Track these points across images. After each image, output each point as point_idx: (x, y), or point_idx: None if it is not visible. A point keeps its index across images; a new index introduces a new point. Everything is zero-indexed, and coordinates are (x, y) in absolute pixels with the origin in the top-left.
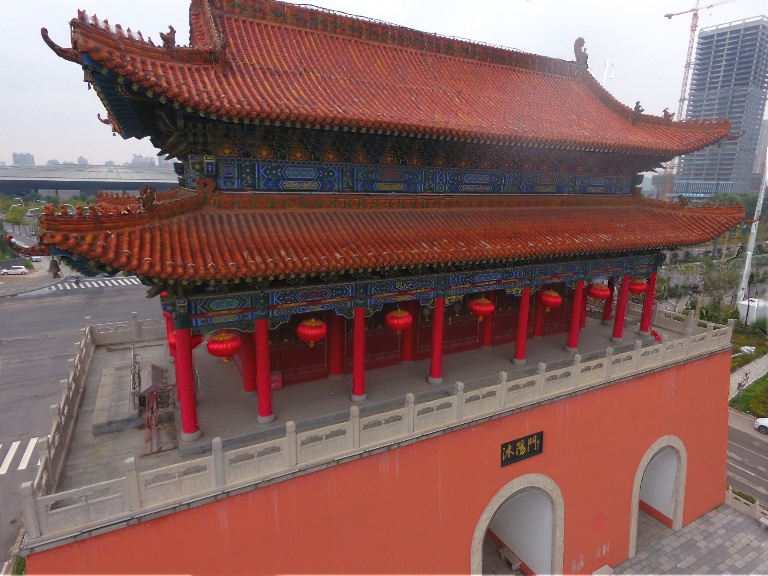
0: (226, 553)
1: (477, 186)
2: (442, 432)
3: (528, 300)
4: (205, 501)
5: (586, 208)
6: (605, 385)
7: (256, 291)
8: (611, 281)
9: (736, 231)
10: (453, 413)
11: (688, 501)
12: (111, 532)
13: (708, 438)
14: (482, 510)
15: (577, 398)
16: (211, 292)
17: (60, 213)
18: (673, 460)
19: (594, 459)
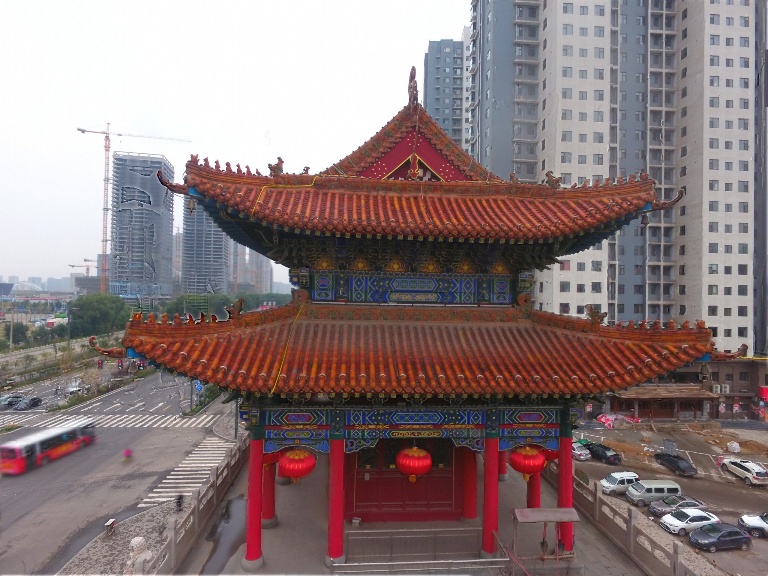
0: None
1: None
2: None
3: None
4: None
5: None
6: None
7: None
8: None
9: None
10: None
11: None
12: None
13: None
14: None
15: None
16: None
17: (692, 327)
18: None
19: None
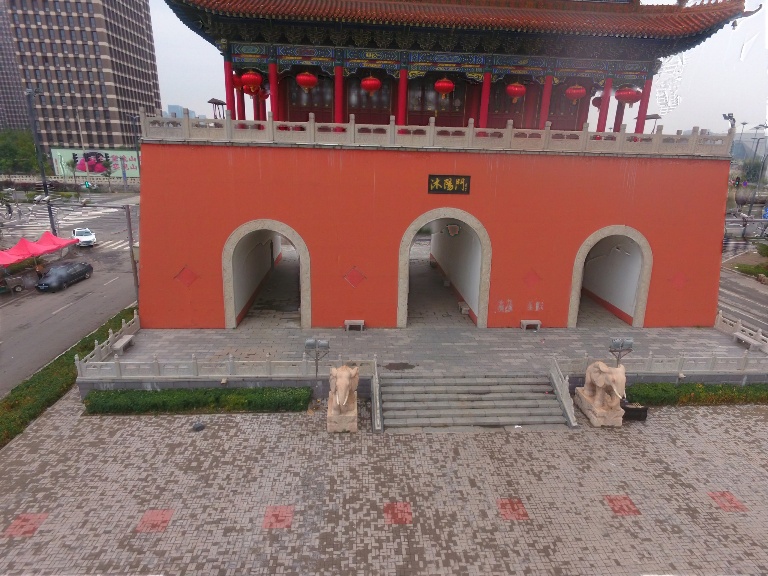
0: (231, 181)
1: None
2: (376, 148)
3: (488, 85)
4: (220, 144)
5: (566, 12)
6: (541, 153)
7: (268, 43)
8: (592, 85)
9: (734, 26)
10: (387, 139)
11: (655, 304)
12: (175, 145)
13: (691, 251)
14: (410, 222)
15: (509, 158)
16: (243, 41)
17: None
18: (638, 259)
19: (528, 219)
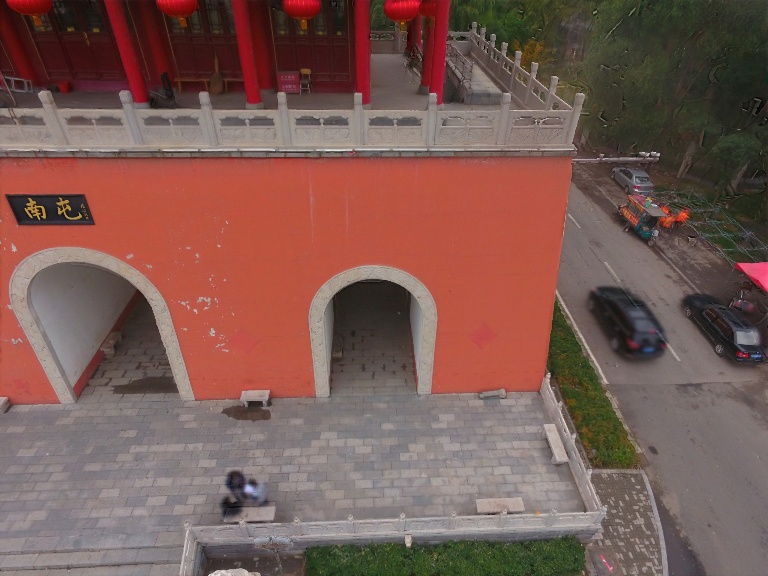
0: None
1: None
2: None
3: None
4: None
5: None
6: None
7: None
8: None
9: None
10: None
11: None
12: None
13: None
14: None
15: None
16: None
17: None
18: None
19: None
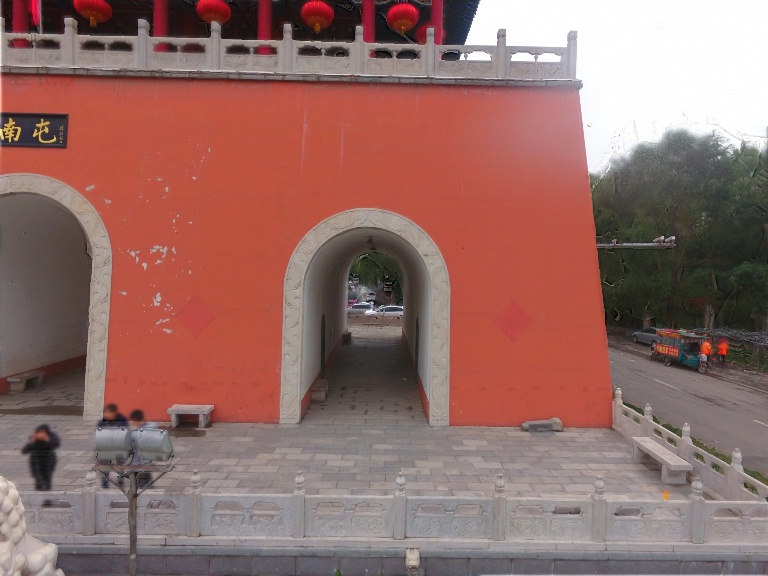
0: None
1: (192, 0)
2: None
3: None
4: None
5: None
6: None
7: None
8: None
9: None
10: None
11: None
12: None
13: None
14: None
15: None
16: None
17: None
18: None
19: None
